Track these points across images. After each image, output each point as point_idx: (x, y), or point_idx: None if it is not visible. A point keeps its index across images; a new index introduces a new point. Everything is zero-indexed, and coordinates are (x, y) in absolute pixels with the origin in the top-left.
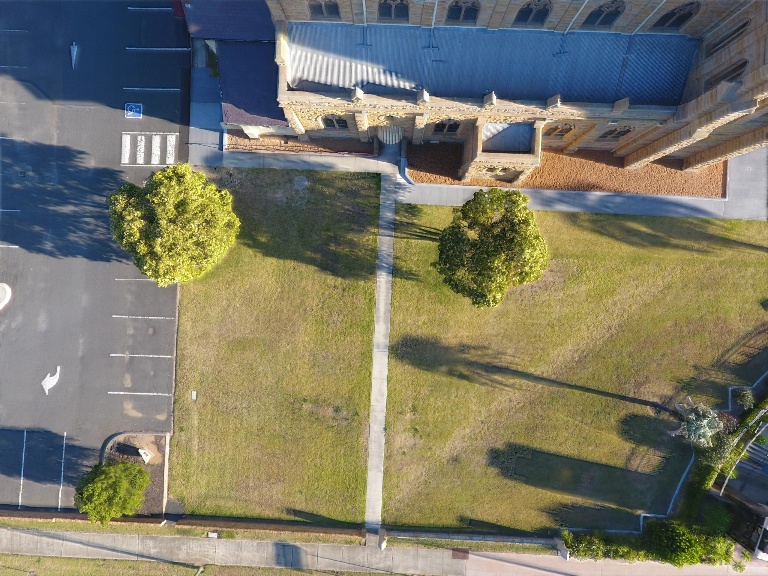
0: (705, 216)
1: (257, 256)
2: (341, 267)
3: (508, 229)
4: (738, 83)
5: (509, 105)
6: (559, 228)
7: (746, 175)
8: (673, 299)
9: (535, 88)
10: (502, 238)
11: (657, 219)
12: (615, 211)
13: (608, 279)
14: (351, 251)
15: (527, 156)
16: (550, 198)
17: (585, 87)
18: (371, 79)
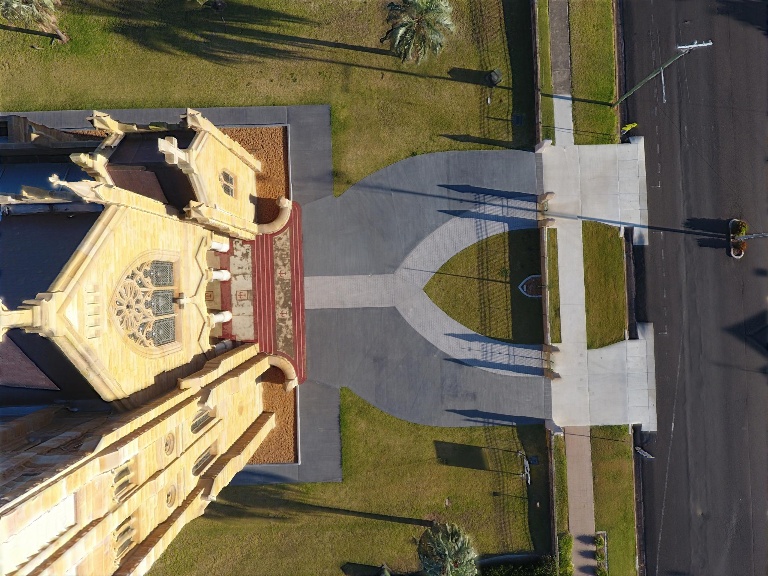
0: (279, 482)
1: None
2: None
3: None
4: None
5: None
6: None
7: (318, 436)
8: (252, 570)
9: None
10: None
11: (230, 489)
12: None
13: (185, 555)
14: None
15: None
16: None
17: None
18: None
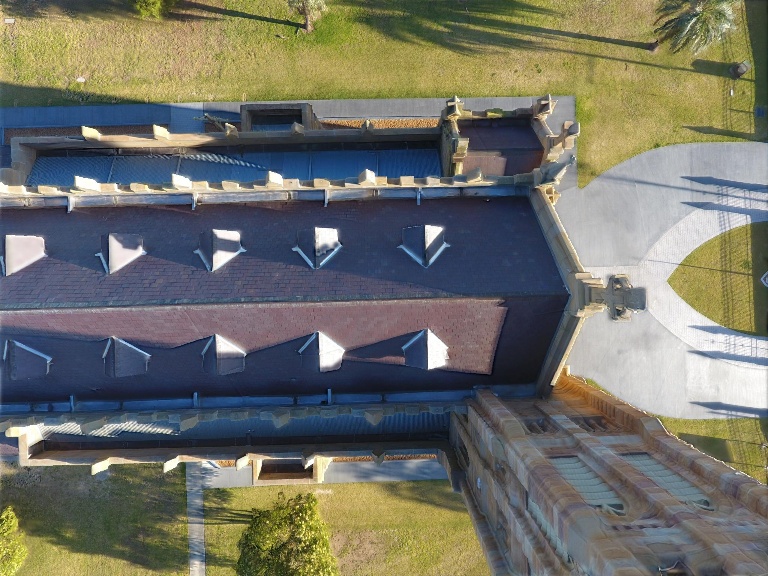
0: None
1: (62, 553)
2: (151, 559)
3: (295, 551)
4: (457, 490)
5: (265, 458)
6: (376, 499)
7: None
8: None
9: (298, 425)
10: (282, 573)
11: None
12: (432, 476)
13: (431, 546)
14: (160, 541)
15: (305, 481)
16: (364, 469)
17: (349, 422)
18: (125, 428)
